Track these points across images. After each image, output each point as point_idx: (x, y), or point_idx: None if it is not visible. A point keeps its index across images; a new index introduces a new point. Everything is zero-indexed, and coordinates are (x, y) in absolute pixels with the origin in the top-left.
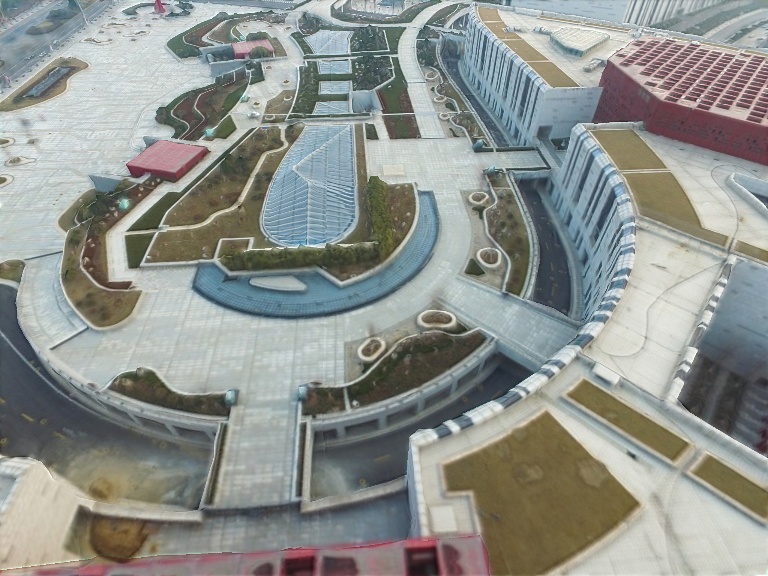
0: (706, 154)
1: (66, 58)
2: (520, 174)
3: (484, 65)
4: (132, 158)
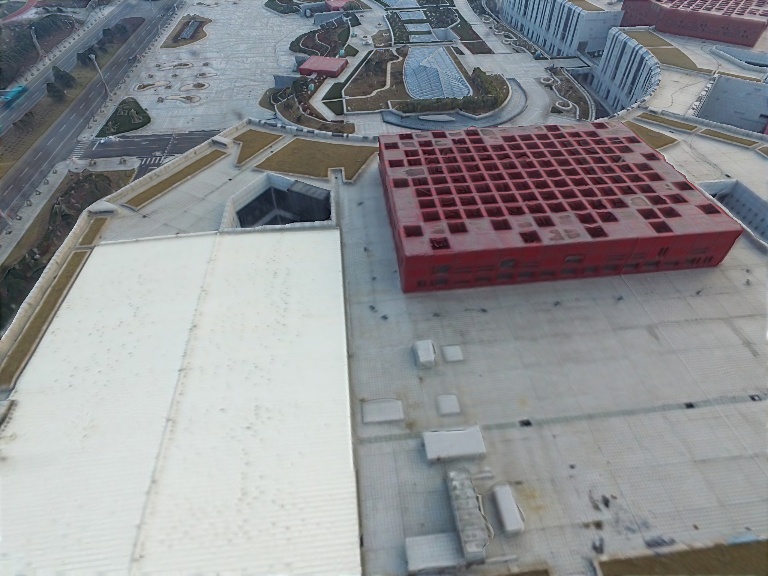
0: (697, 40)
1: (191, 15)
2: (570, 70)
3: (528, 10)
4: (287, 72)
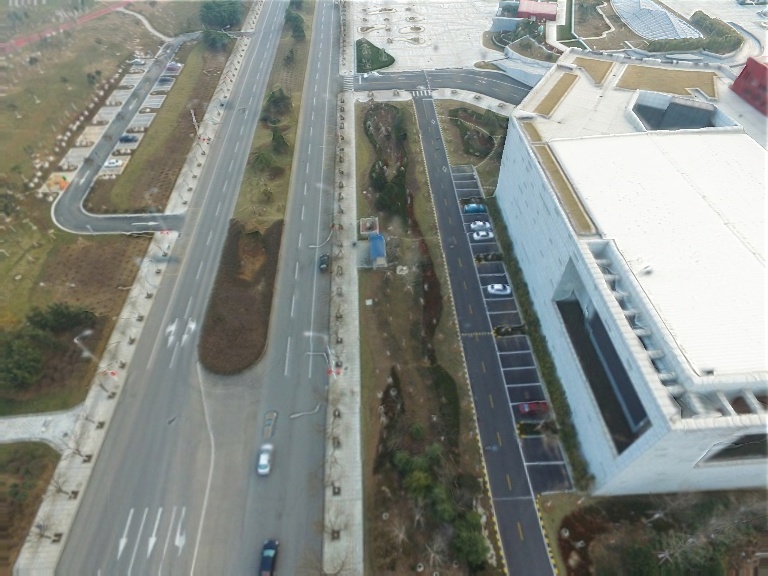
0: None
1: None
2: None
3: None
4: (490, 17)
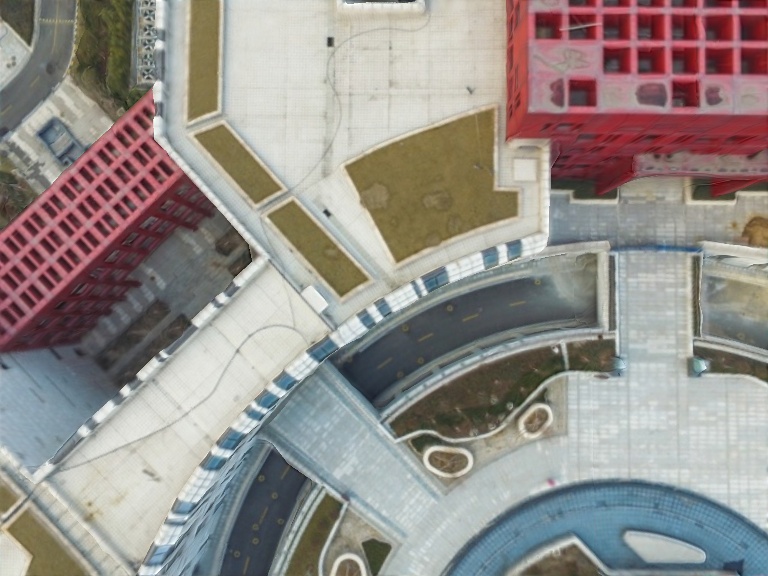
0: None
1: None
2: None
3: None
4: None
